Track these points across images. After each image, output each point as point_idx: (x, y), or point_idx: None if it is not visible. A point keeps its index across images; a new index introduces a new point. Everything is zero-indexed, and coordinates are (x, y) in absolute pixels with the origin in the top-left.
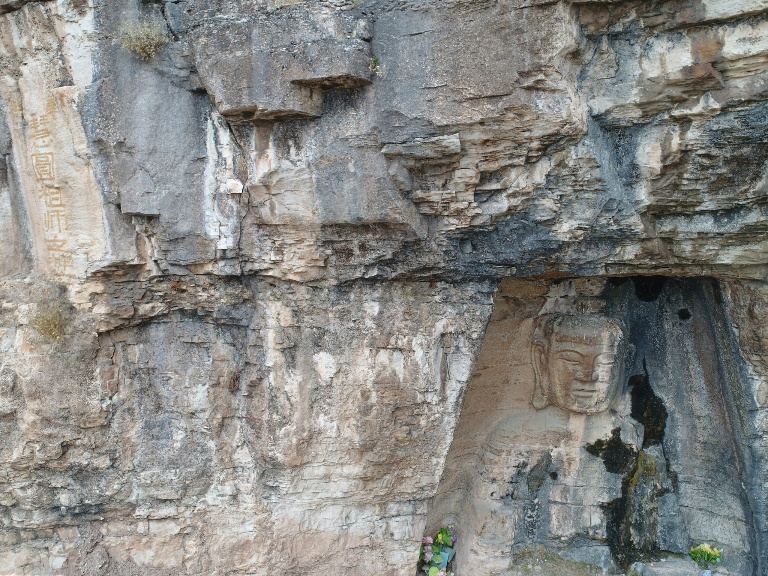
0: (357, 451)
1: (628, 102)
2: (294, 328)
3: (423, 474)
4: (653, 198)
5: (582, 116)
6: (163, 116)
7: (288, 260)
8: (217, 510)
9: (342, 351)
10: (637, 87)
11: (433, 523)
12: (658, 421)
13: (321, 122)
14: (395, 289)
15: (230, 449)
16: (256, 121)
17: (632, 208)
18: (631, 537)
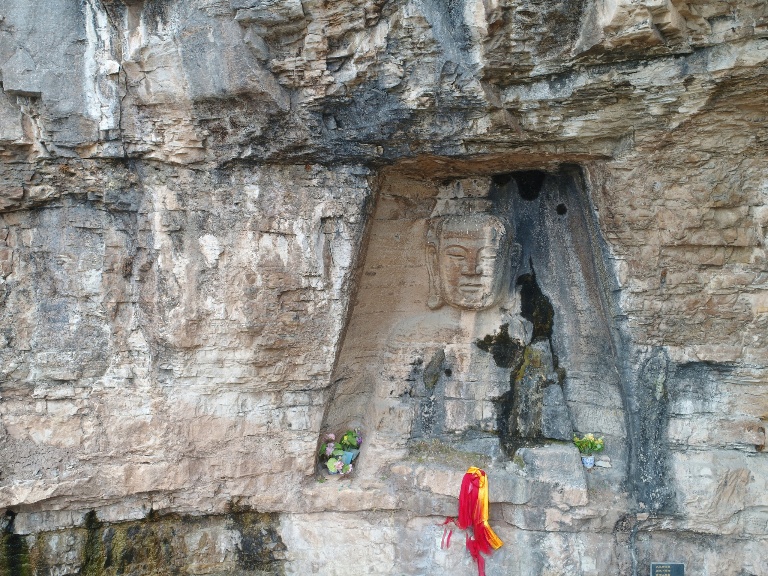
0: (247, 335)
1: None
2: (180, 212)
3: (315, 362)
4: (486, 60)
5: None
6: None
7: (168, 142)
8: (114, 392)
9: (225, 233)
10: None
11: (338, 423)
12: (546, 319)
13: None
14: (273, 172)
15: (125, 333)
16: None
17: (470, 73)
18: (517, 426)
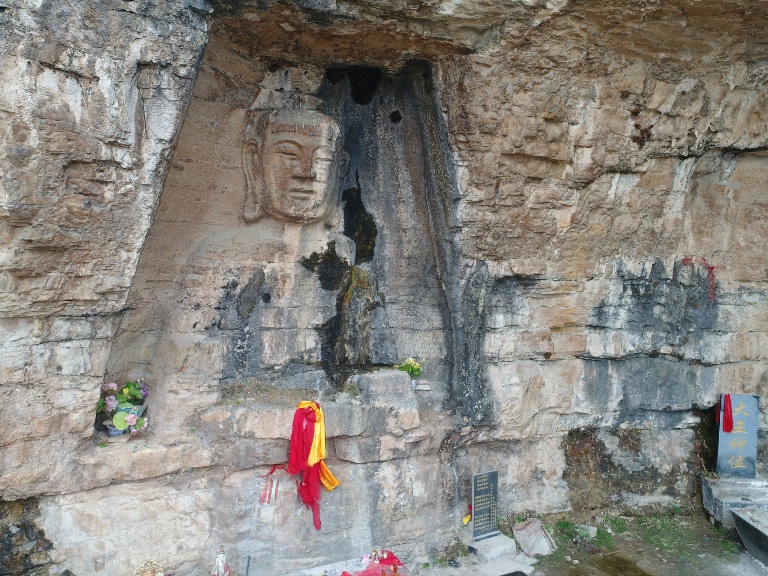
0: (4, 224)
1: None
2: None
3: (107, 274)
4: None
5: None
6: None
7: None
8: None
9: None
10: None
11: (117, 371)
12: (368, 239)
13: None
14: None
15: None
16: None
17: None
18: (346, 353)
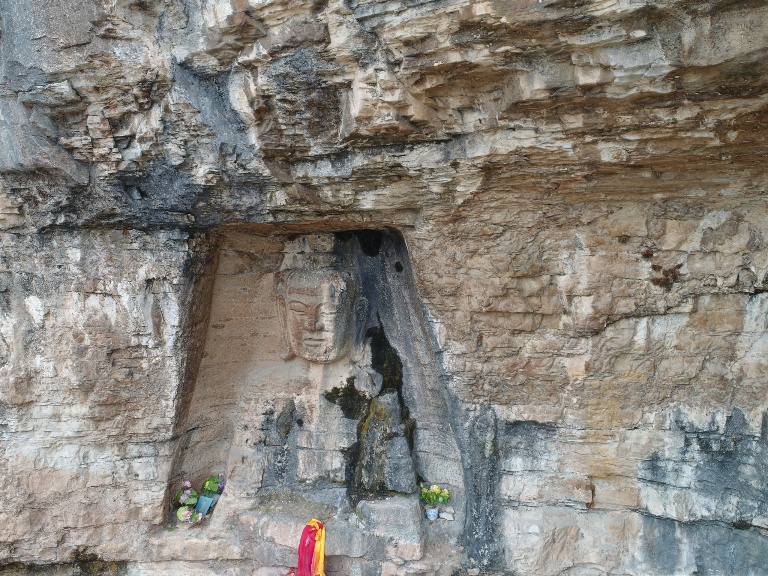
0: (80, 391)
1: (199, 50)
2: (6, 273)
3: (155, 416)
4: (261, 142)
5: (163, 63)
6: None
7: None
8: None
9: (49, 295)
10: (202, 36)
11: (197, 470)
12: (395, 371)
13: None
14: (94, 236)
15: None
16: None
17: (249, 152)
18: (362, 478)
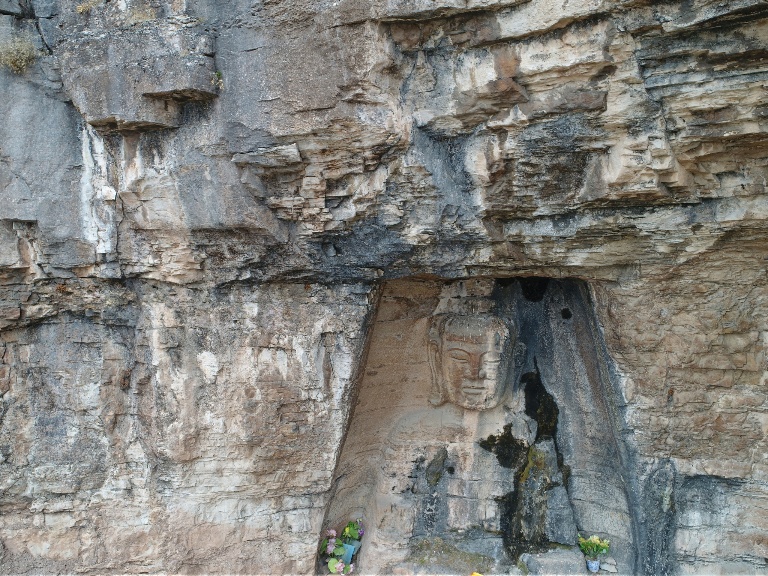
0: (246, 446)
1: (446, 114)
2: (178, 328)
3: (315, 469)
4: (488, 204)
5: (406, 127)
6: (38, 126)
7: (166, 263)
8: (112, 504)
9: (224, 350)
10: (453, 100)
11: (339, 517)
12: (550, 417)
13: (179, 132)
14: (272, 291)
15: (123, 445)
16: (123, 131)
17: (472, 213)
18: (521, 529)
